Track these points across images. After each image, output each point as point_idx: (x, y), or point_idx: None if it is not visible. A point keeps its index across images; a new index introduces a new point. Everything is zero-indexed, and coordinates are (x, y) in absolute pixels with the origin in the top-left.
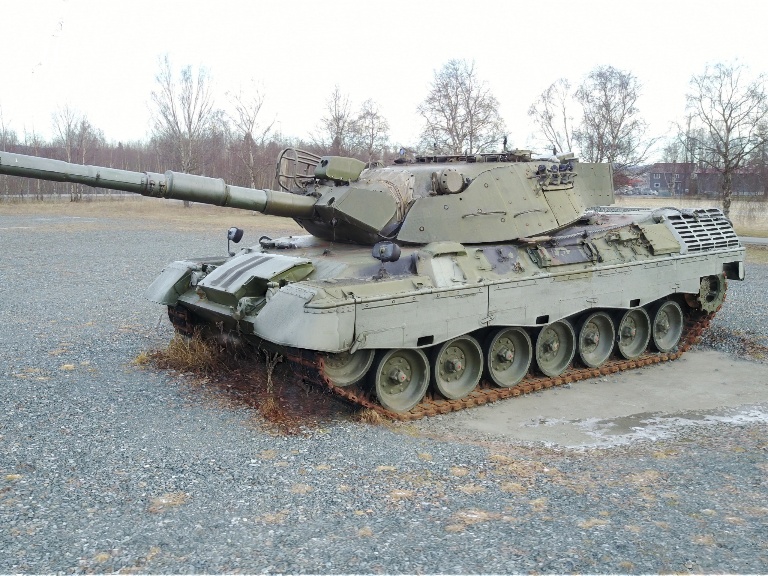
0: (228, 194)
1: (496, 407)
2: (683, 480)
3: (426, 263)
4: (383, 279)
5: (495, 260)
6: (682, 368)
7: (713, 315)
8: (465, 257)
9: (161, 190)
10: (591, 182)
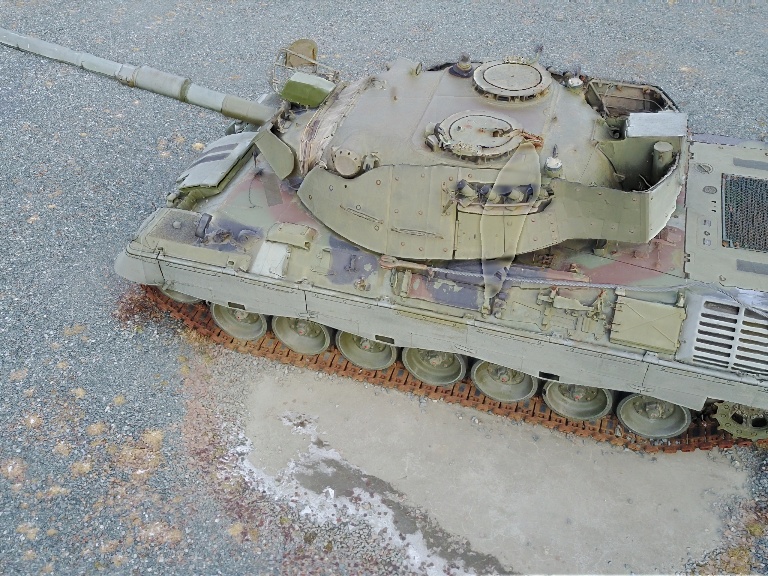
0: (185, 97)
1: (319, 380)
2: (166, 560)
3: (258, 243)
4: (210, 242)
5: (341, 266)
6: (606, 467)
7: (744, 442)
8: (306, 251)
9: (128, 84)
10: (597, 209)
